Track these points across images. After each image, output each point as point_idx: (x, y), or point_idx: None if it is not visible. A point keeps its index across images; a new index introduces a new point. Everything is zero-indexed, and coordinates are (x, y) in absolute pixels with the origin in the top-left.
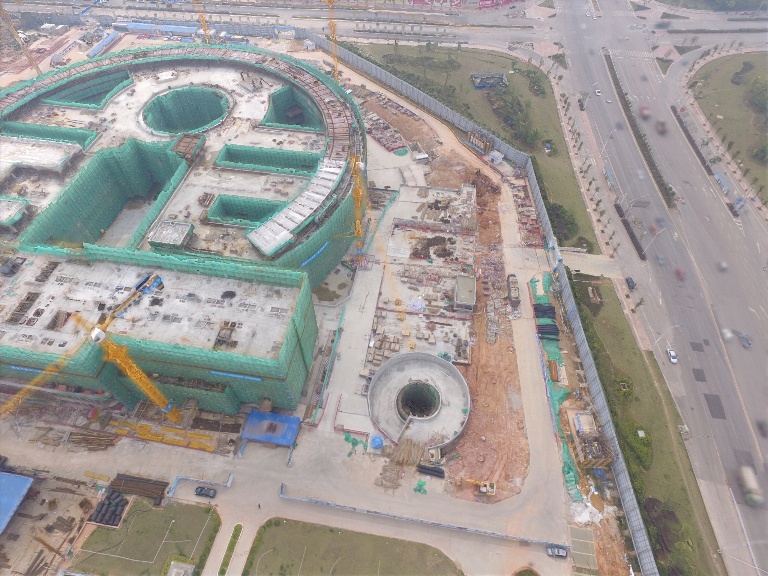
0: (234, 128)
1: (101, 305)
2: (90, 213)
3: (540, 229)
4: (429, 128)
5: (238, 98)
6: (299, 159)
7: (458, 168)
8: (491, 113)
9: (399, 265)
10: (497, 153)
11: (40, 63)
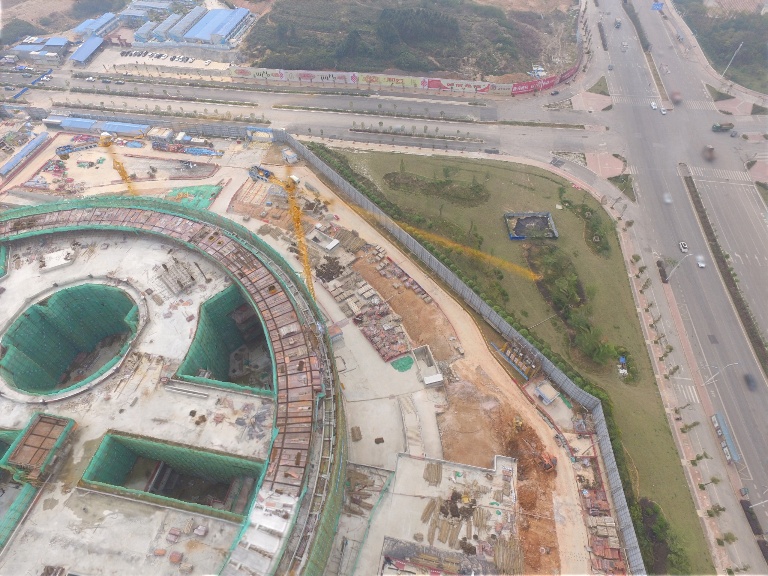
0: (134, 380)
1: None
2: None
3: (626, 568)
4: (445, 320)
5: (154, 308)
6: (227, 461)
7: (488, 405)
8: (534, 290)
9: None
10: (548, 388)
11: None
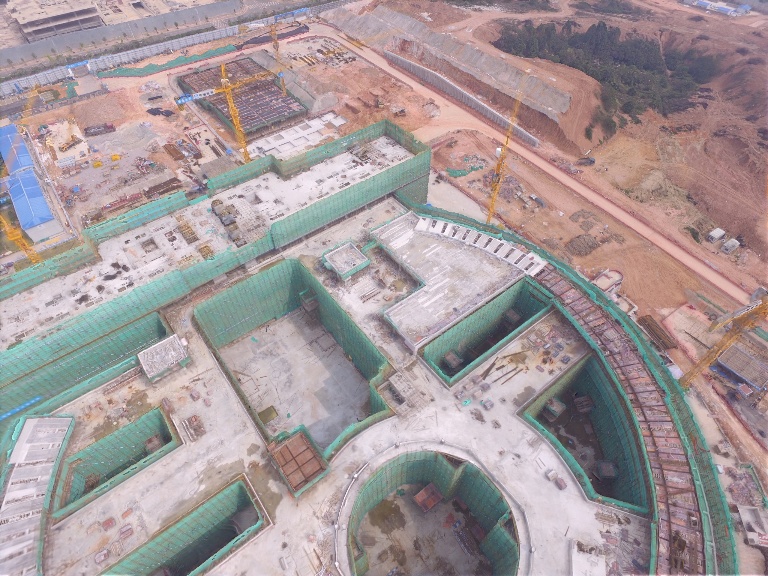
0: None
1: (124, 267)
2: None
3: None
4: None
5: None
6: None
7: None
8: None
9: None
10: None
11: None
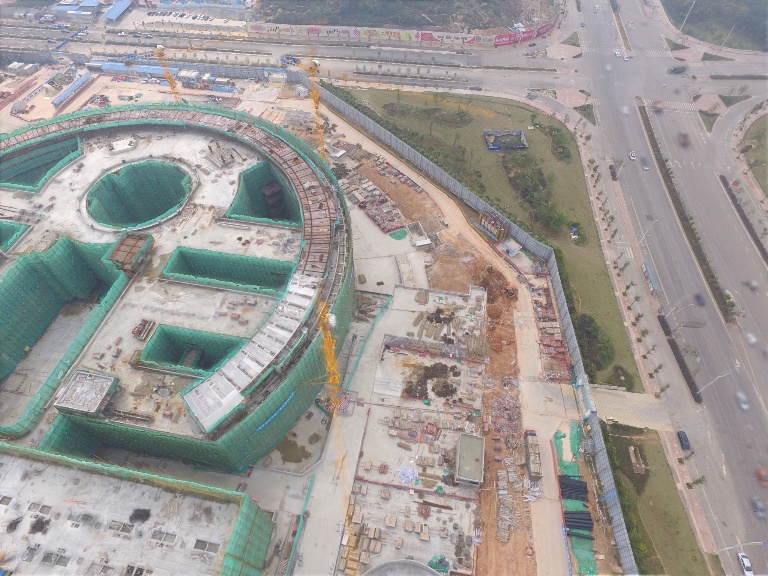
0: (193, 220)
1: None
2: (8, 332)
3: (566, 353)
4: (433, 203)
5: (203, 176)
6: (267, 266)
7: (466, 259)
8: (507, 184)
9: (388, 408)
10: (513, 243)
11: (0, 111)
